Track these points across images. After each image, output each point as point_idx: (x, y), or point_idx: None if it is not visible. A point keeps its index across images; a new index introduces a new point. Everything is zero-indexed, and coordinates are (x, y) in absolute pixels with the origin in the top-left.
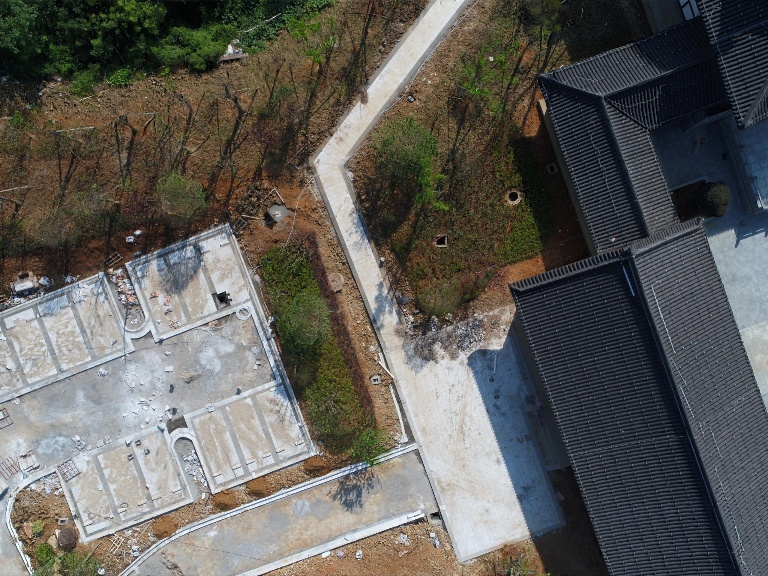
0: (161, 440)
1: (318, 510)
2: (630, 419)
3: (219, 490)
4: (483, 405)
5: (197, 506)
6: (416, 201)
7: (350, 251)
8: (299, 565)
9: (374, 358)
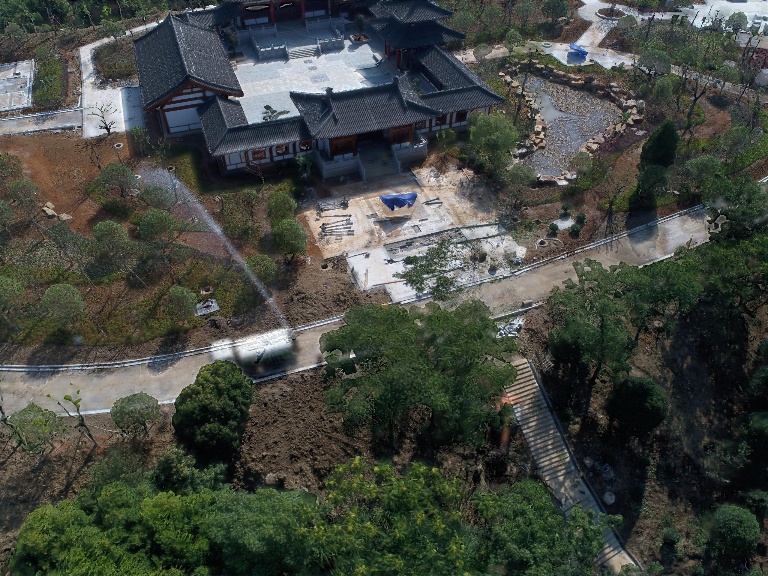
0: None
1: None
2: None
3: None
4: (121, 99)
5: None
6: None
7: (83, 66)
8: None
9: None
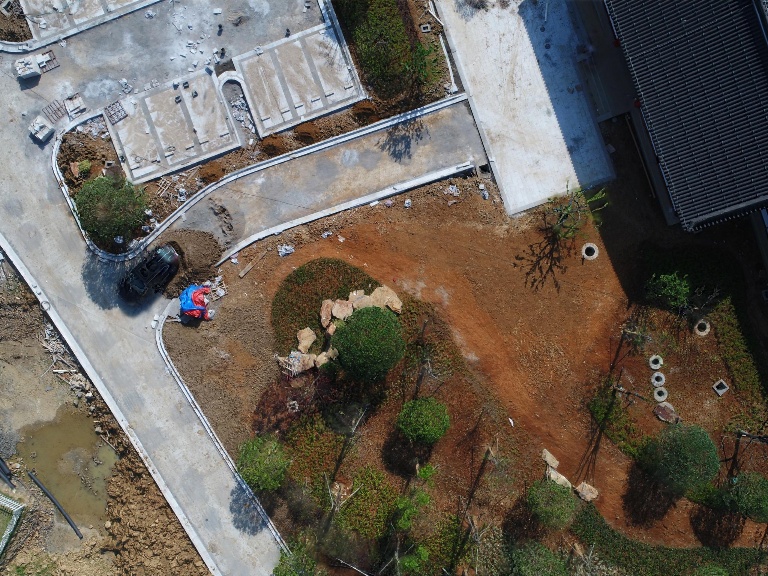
0: (209, 83)
1: (366, 160)
2: (692, 4)
3: (267, 134)
4: (534, 55)
5: (245, 152)
6: None
7: None
8: (347, 213)
9: (424, 5)
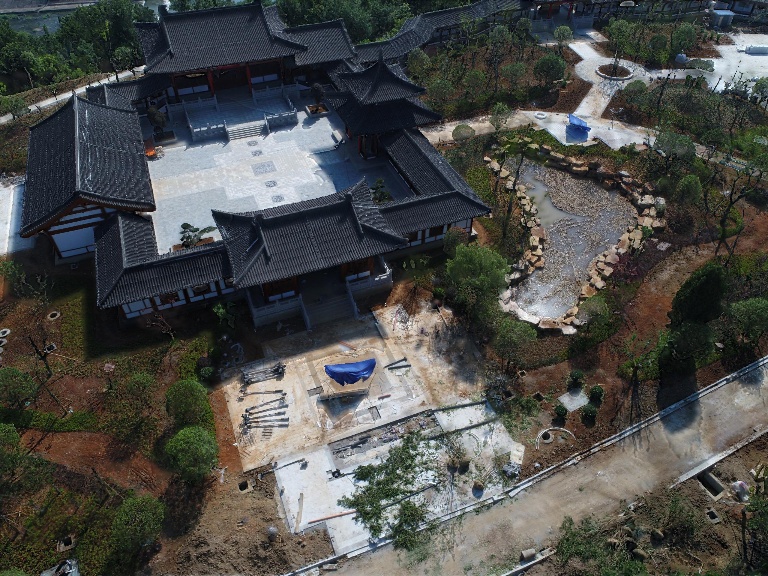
0: None
1: None
2: None
3: None
4: None
5: None
6: (17, 135)
7: None
8: None
9: None
